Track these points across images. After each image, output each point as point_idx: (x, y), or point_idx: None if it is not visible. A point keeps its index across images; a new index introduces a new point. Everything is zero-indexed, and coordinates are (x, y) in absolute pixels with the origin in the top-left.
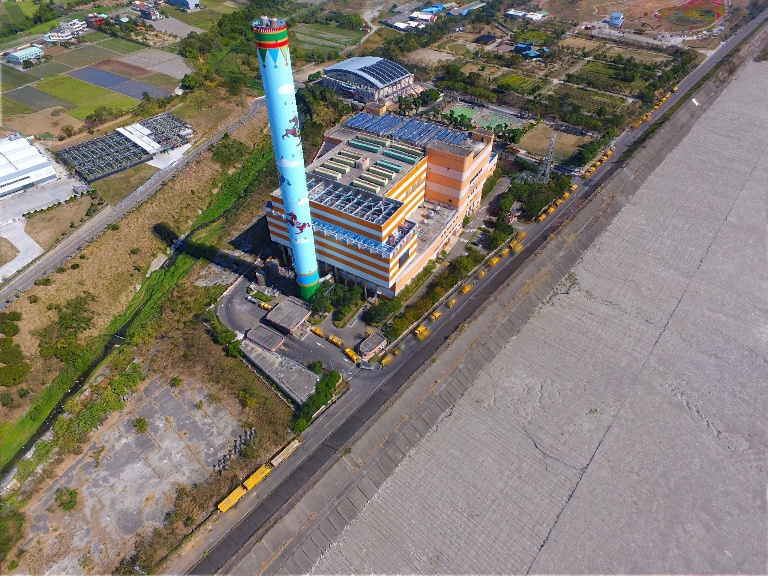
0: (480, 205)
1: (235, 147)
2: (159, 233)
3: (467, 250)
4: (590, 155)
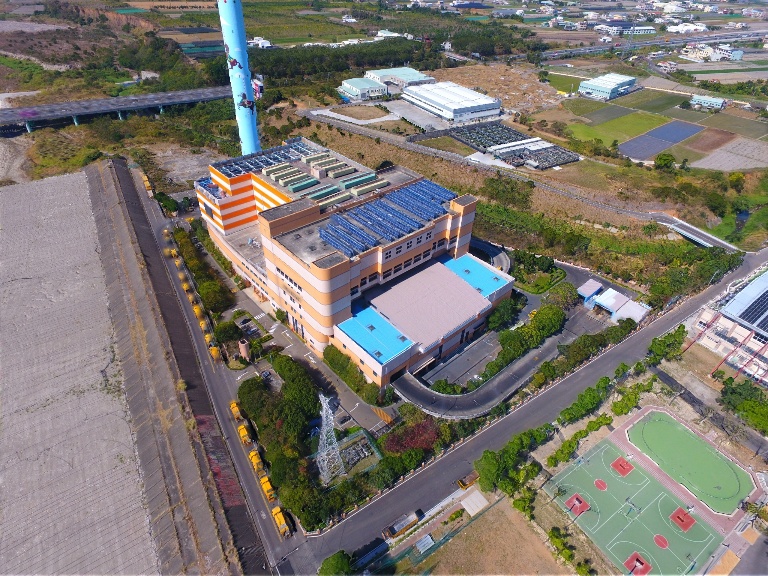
0: (320, 358)
1: (507, 188)
2: (382, 165)
3: None
4: (323, 573)
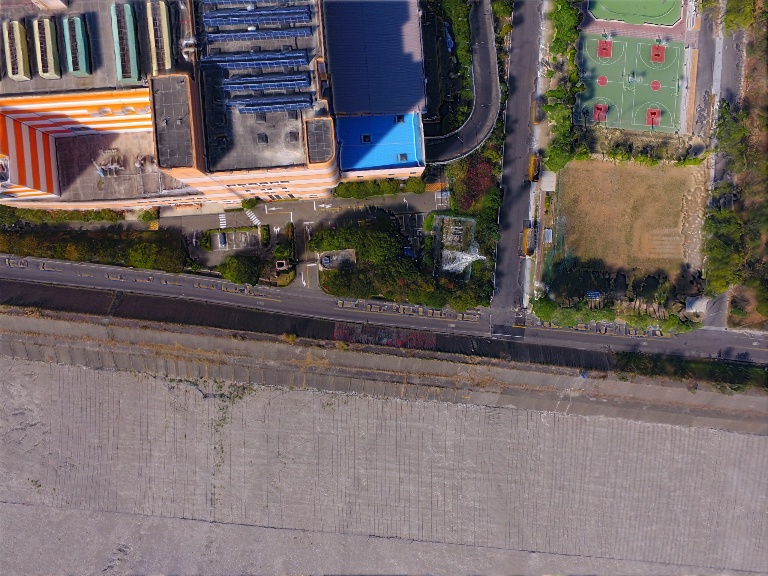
0: (329, 197)
1: None
2: None
3: (201, 237)
4: (547, 319)
